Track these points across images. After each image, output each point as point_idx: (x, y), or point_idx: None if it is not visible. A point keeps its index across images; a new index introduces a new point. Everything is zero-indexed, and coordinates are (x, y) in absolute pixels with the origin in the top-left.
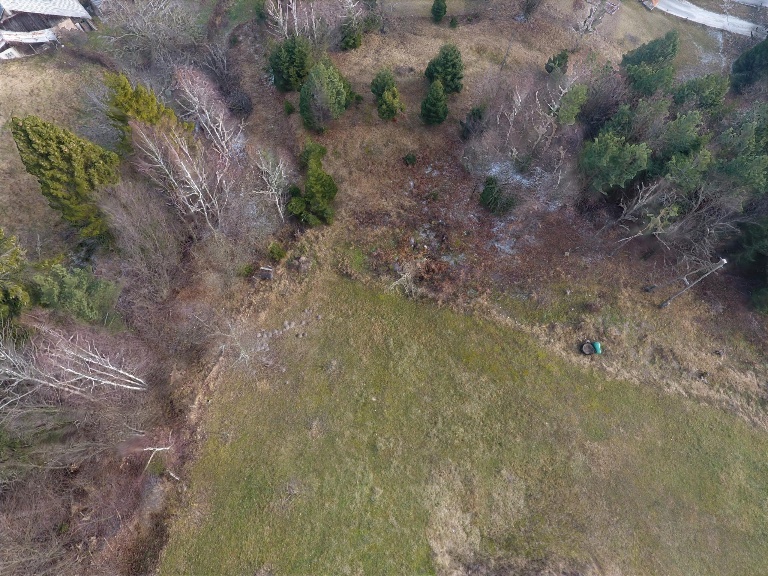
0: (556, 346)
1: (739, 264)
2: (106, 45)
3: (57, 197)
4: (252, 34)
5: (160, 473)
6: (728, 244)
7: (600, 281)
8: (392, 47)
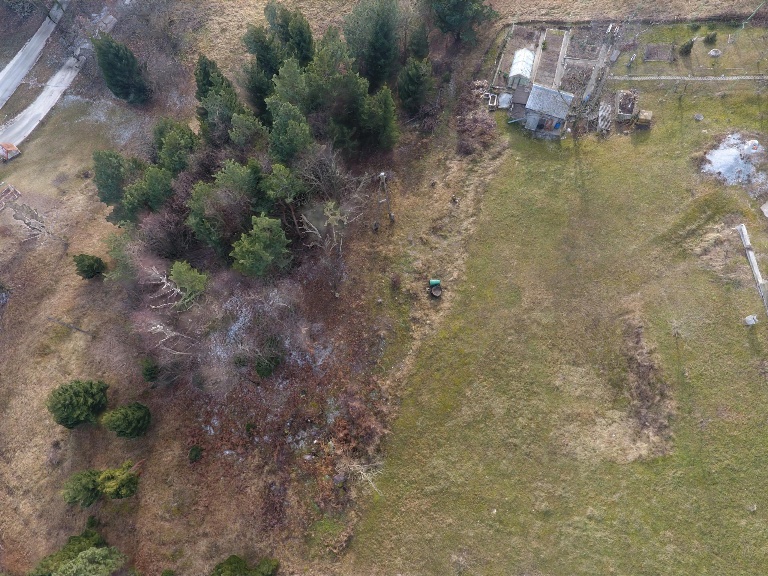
0: (434, 319)
1: None
2: None
3: None
4: None
5: None
6: (342, 158)
7: (369, 269)
8: (7, 469)
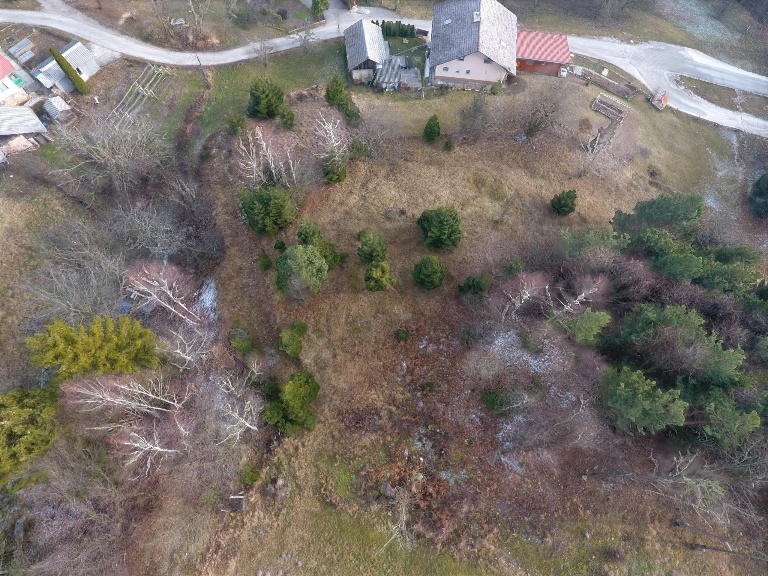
0: None
1: None
2: (59, 178)
3: None
4: (226, 147)
5: None
6: None
7: (624, 519)
8: (381, 178)
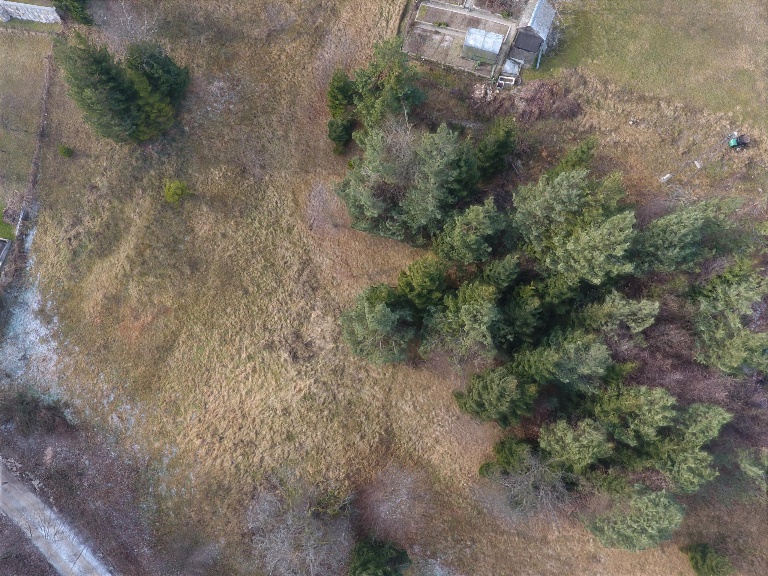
0: None
1: None
2: None
3: None
4: None
5: None
6: None
7: None
8: None
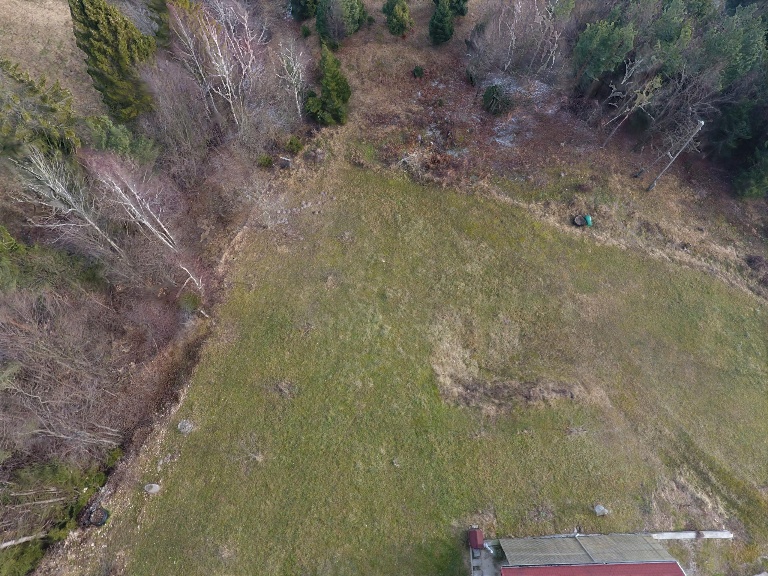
0: (550, 219)
1: (722, 154)
2: None
3: (102, 71)
4: None
5: (192, 311)
6: (711, 130)
7: (592, 166)
8: None
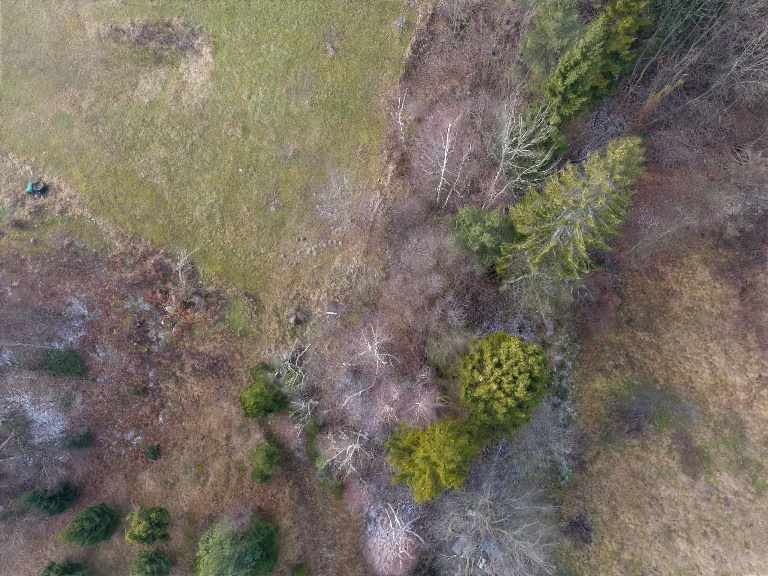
0: (66, 193)
1: None
2: None
3: None
4: None
5: None
6: None
7: None
8: None
